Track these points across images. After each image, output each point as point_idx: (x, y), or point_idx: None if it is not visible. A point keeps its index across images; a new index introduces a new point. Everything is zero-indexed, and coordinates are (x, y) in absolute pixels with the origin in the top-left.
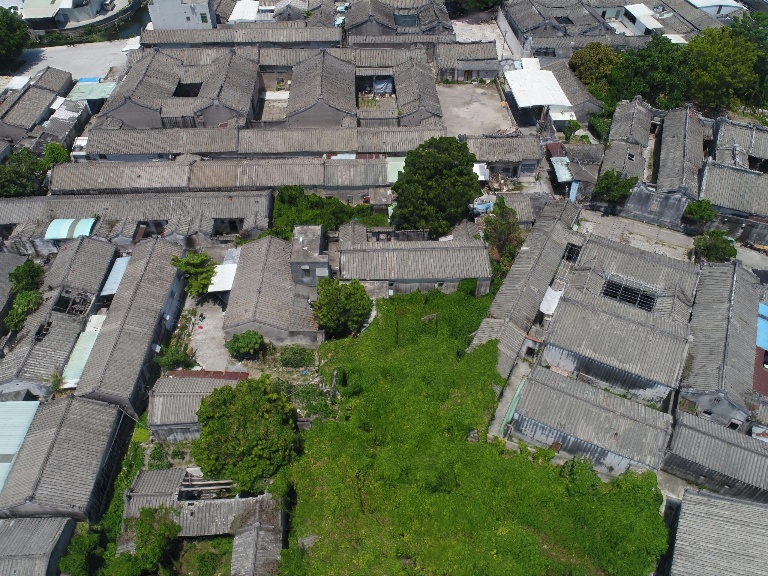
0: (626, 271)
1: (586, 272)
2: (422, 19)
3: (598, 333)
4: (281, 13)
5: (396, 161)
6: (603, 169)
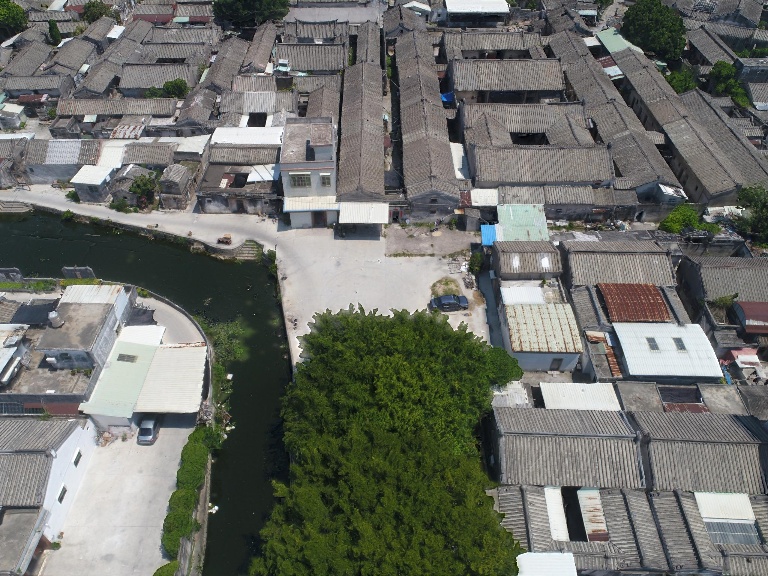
0: (688, 5)
1: (696, 13)
2: (316, 35)
3: (749, 12)
4: (294, 101)
5: (625, 45)
6: (583, 0)
